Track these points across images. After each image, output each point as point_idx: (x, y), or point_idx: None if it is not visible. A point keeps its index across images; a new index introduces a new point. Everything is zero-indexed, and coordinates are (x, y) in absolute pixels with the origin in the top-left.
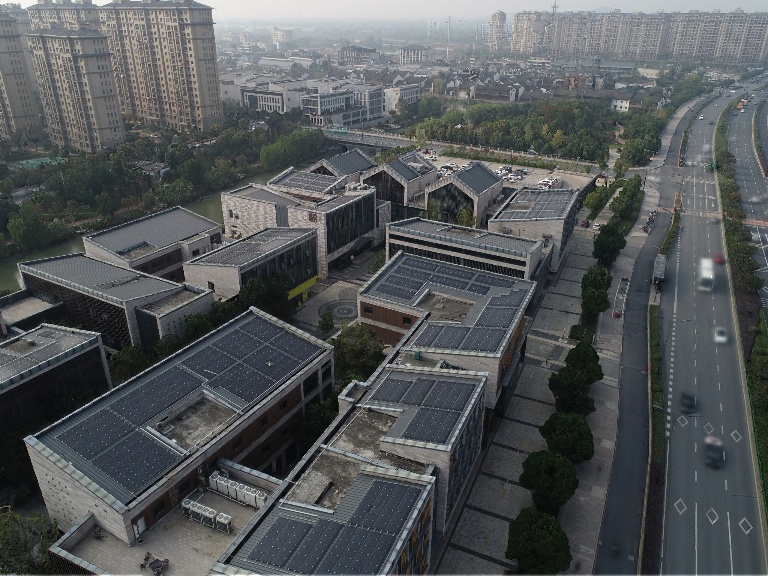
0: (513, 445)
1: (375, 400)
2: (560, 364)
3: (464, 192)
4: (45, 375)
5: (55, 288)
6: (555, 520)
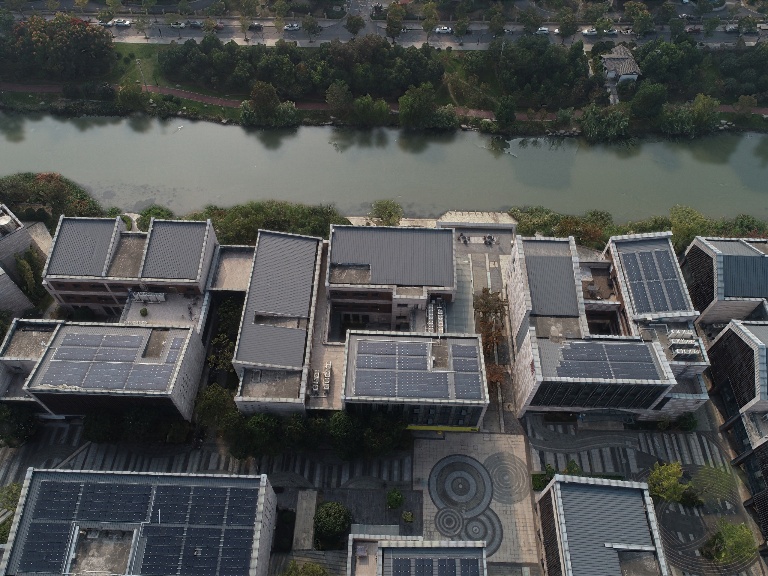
0: None
1: None
2: None
3: None
4: (123, 396)
5: None
6: None
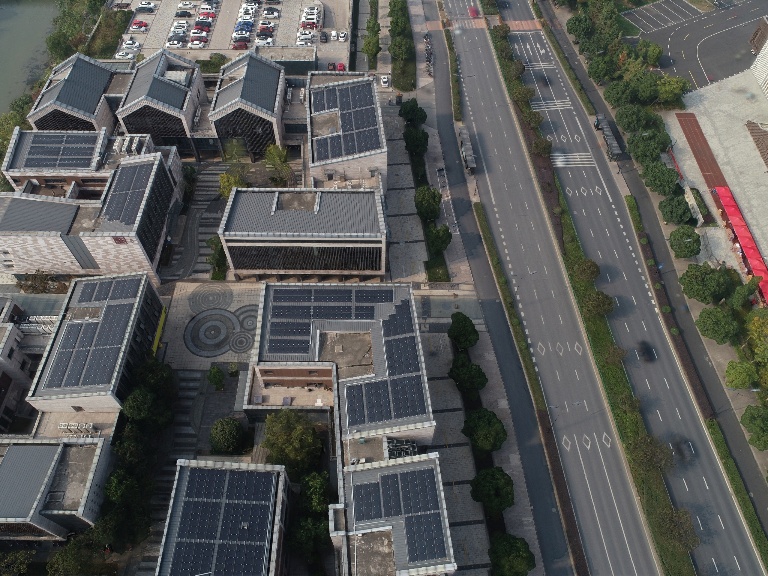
0: (441, 442)
1: (361, 521)
2: (435, 321)
3: (258, 115)
4: None
5: None
6: (522, 545)
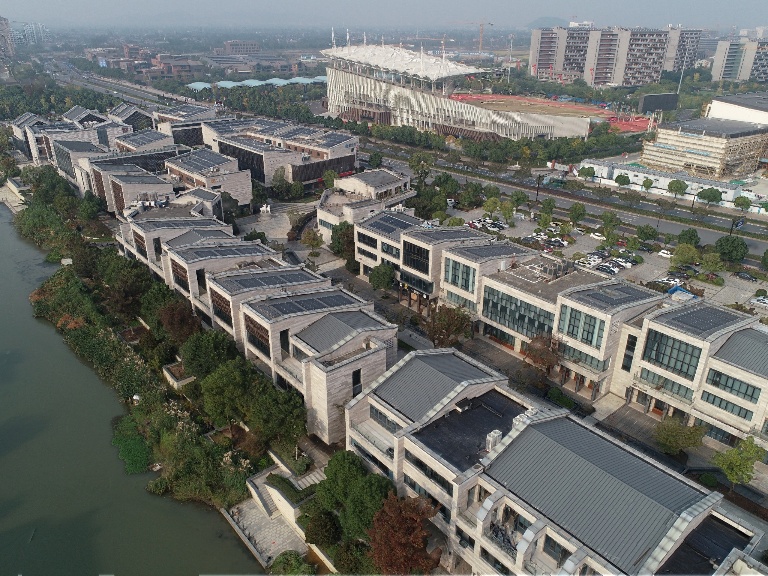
0: None
1: None
2: None
3: (145, 115)
4: None
5: (121, 161)
6: None
